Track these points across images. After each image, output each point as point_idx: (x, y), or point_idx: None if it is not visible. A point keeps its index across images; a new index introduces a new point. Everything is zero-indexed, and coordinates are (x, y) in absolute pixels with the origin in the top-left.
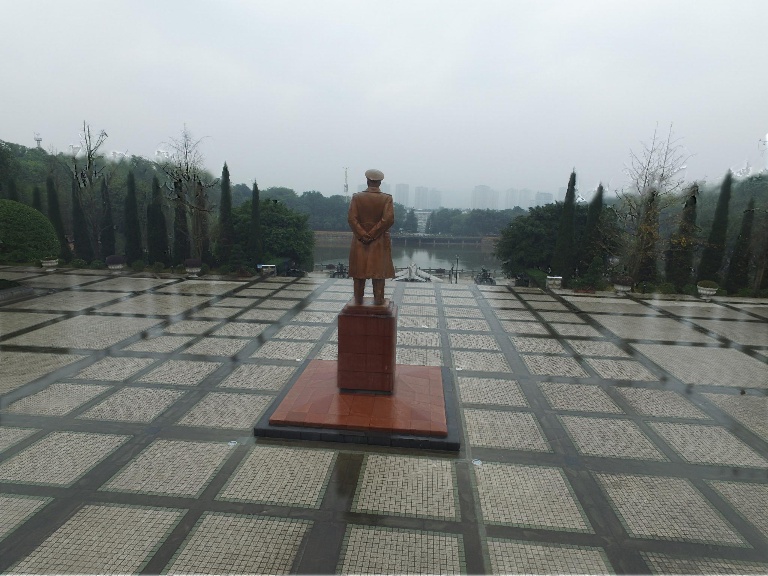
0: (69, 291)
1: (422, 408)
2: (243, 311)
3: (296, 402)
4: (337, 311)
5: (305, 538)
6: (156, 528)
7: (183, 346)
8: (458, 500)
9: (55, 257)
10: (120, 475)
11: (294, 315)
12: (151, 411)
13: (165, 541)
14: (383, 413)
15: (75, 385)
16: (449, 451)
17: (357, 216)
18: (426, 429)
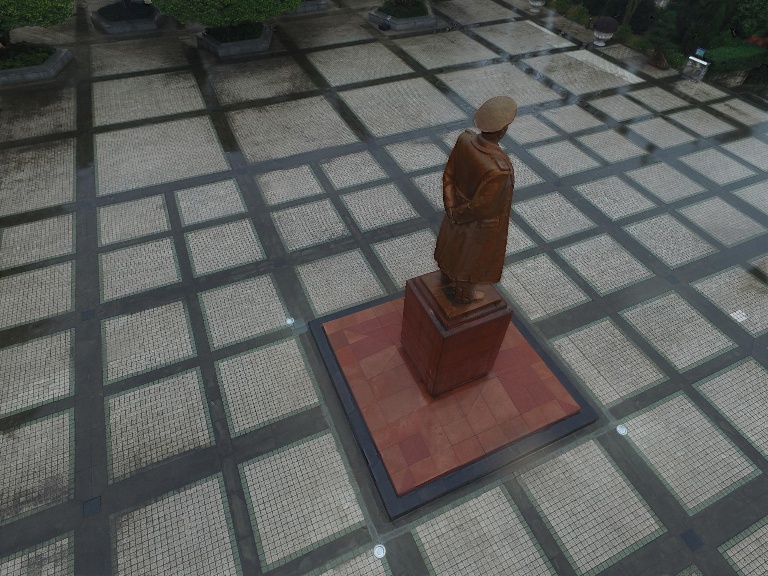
0: (460, 32)
1: (430, 443)
2: (552, 140)
3: (363, 323)
4: (661, 201)
5: (193, 450)
6: (172, 353)
7: (426, 169)
8: (296, 557)
9: None
10: (217, 291)
11: (594, 178)
12: (304, 240)
13: (162, 367)
14: (391, 409)
15: (311, 175)
16: (384, 509)
17: (452, 173)
18: (389, 469)
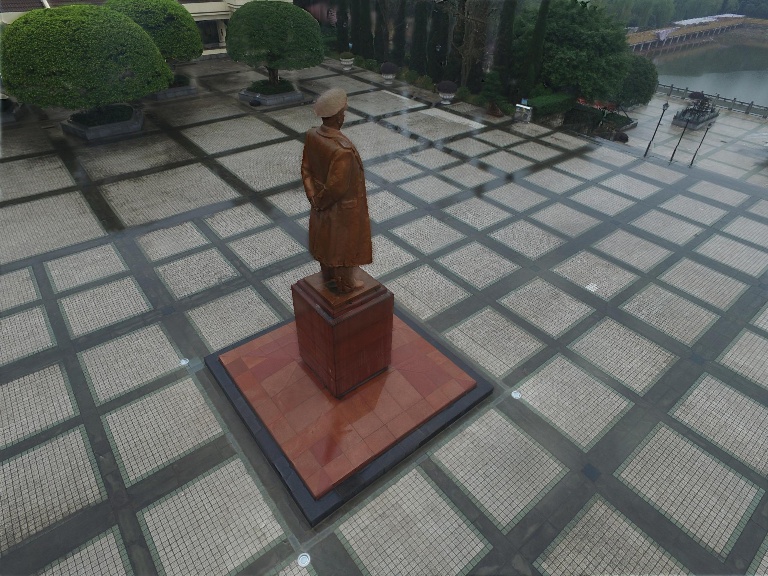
0: None
1: (341, 441)
2: (418, 176)
3: (260, 348)
4: (515, 211)
5: (81, 510)
6: (50, 417)
7: (308, 211)
8: None
9: (350, 56)
10: (100, 347)
11: (458, 201)
12: (193, 287)
13: (38, 434)
14: (298, 419)
15: (195, 229)
16: (304, 518)
17: (308, 166)
18: (303, 475)
